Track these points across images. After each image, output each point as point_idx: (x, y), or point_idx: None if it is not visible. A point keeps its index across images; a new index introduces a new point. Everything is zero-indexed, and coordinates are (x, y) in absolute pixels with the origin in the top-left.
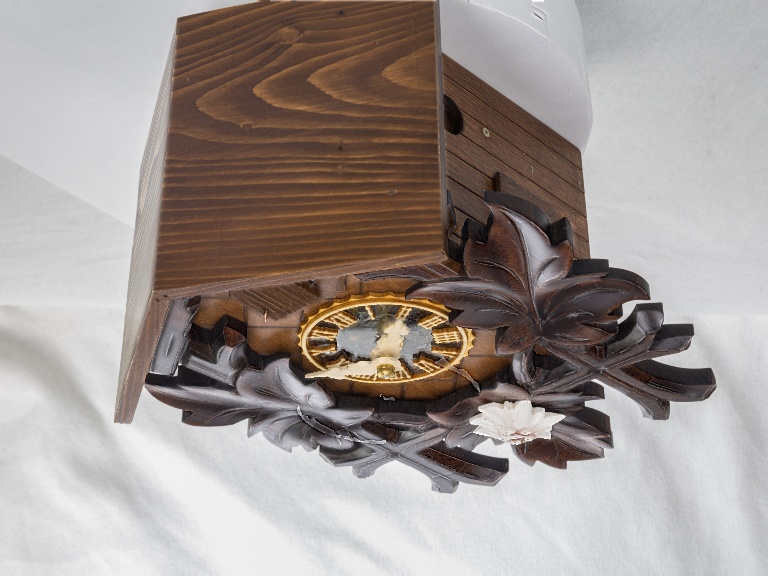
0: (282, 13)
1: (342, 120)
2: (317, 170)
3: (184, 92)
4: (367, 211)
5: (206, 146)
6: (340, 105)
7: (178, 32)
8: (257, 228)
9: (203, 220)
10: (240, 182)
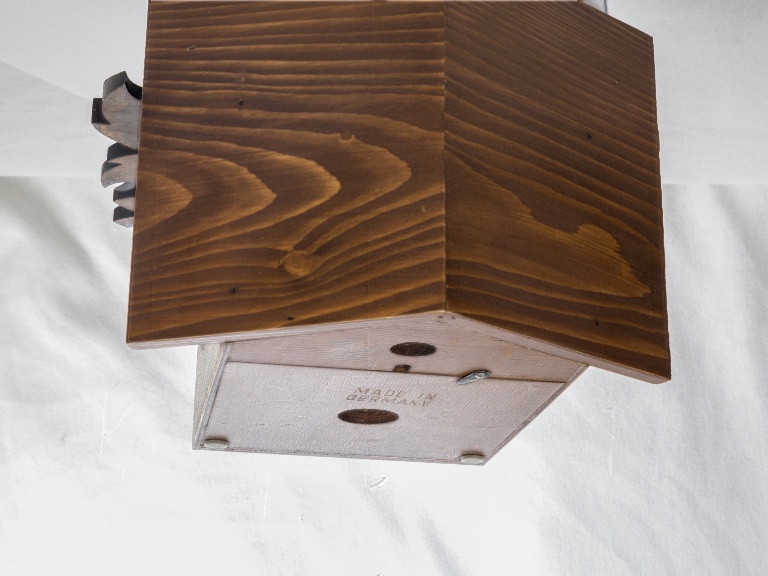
0: (305, 299)
1: (238, 138)
2: (267, 76)
3: (427, 190)
4: (217, 27)
5: (394, 111)
6: (240, 158)
7: (442, 285)
8: (331, 7)
9: (392, 17)
10: (352, 63)
